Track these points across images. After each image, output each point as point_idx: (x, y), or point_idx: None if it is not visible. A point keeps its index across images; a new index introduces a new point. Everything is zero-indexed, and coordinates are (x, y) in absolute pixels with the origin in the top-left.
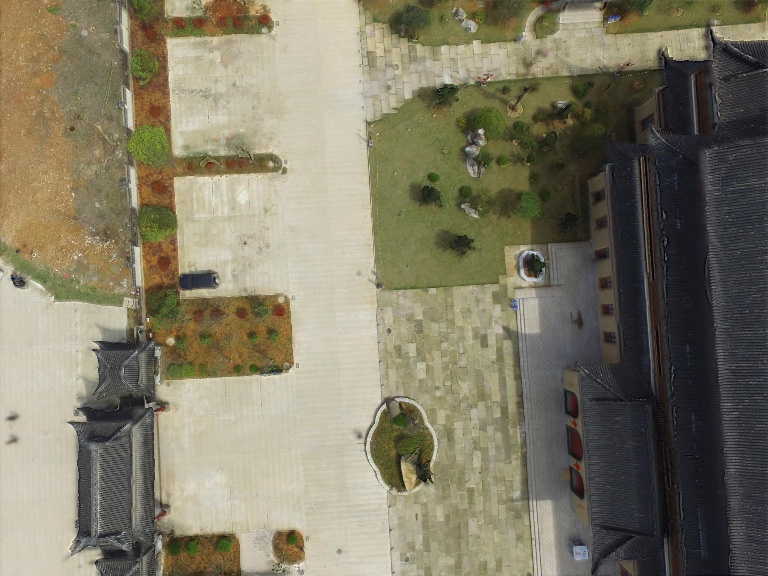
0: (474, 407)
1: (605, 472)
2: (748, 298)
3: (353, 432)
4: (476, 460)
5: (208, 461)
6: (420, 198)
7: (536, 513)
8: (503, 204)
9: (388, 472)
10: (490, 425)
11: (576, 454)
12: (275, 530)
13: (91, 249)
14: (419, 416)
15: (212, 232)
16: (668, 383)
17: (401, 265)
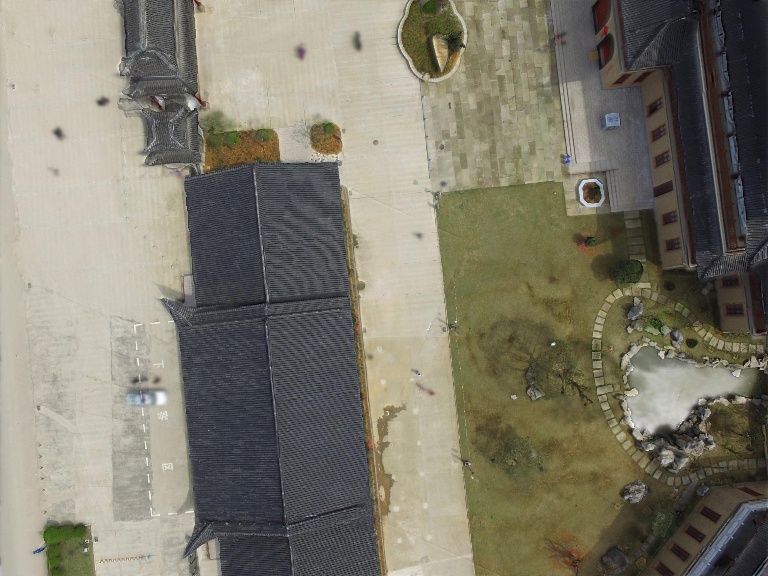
0: None
1: None
2: None
3: (384, 27)
4: (505, 49)
5: (244, 60)
6: None
7: (567, 95)
8: None
9: (420, 58)
10: (518, 15)
11: (604, 23)
12: (312, 123)
13: None
14: (448, 5)
15: None
16: None
17: None
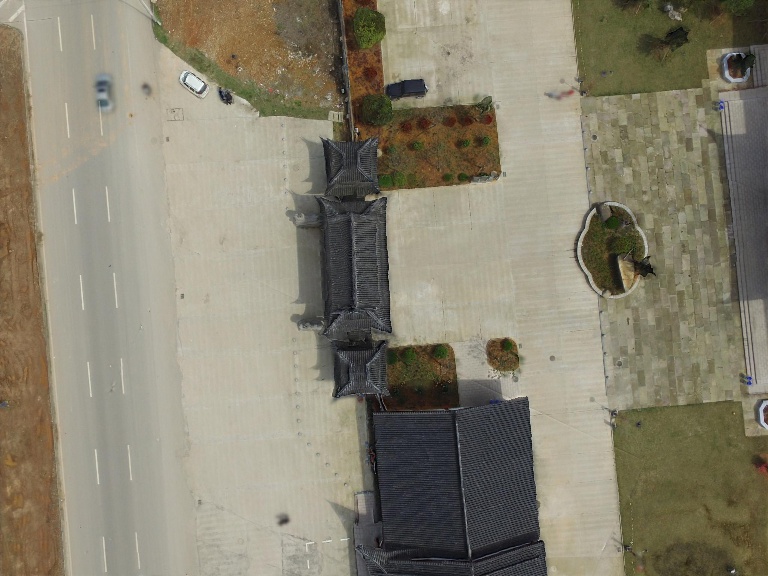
0: (682, 211)
1: None
2: None
3: (562, 239)
4: (685, 263)
5: (419, 271)
6: (623, 3)
7: (748, 313)
8: (705, 7)
9: (601, 275)
10: (698, 228)
11: None
12: (488, 338)
13: (295, 63)
14: (629, 219)
15: (415, 43)
16: None
17: None
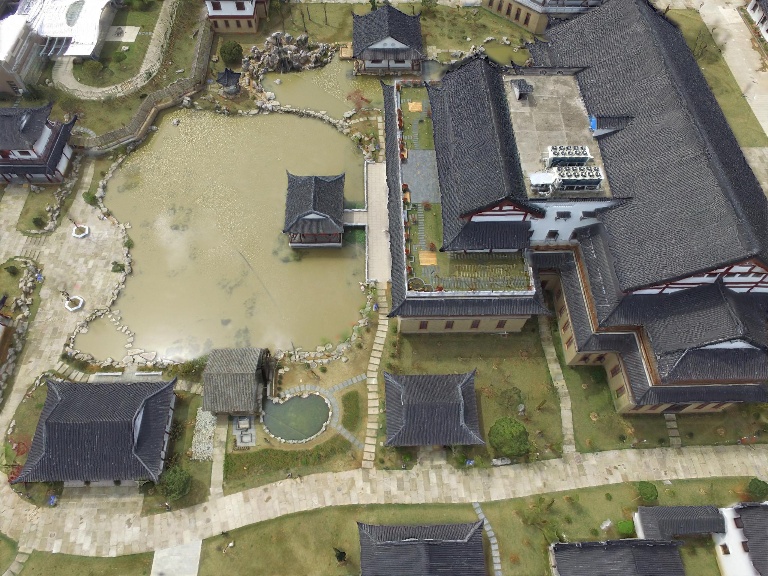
0: None
1: None
2: (766, 211)
3: None
4: None
5: None
6: None
7: None
8: None
9: None
10: None
11: None
12: None
13: None
14: None
15: None
16: None
17: None
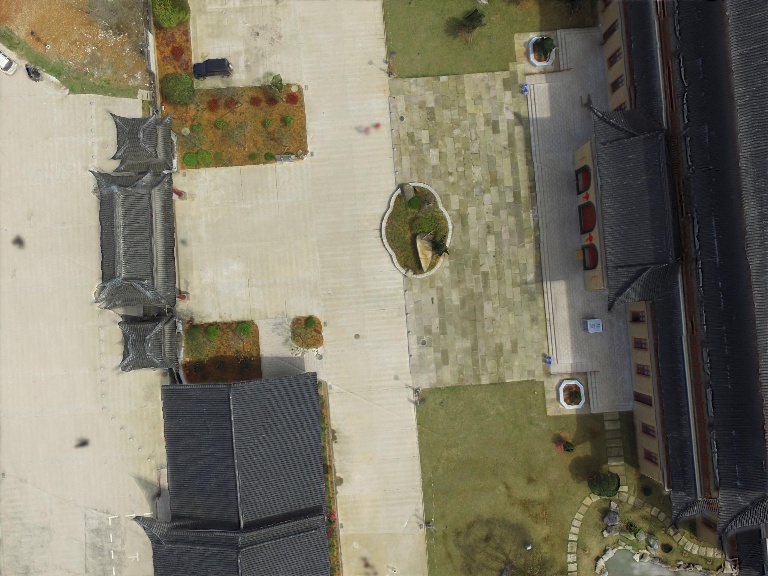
0: (487, 192)
1: (620, 213)
2: None
3: (368, 219)
4: (490, 244)
5: (225, 249)
6: None
7: (550, 294)
8: None
9: (404, 254)
10: (503, 210)
11: (589, 228)
12: (293, 316)
13: (105, 41)
14: (433, 200)
15: (224, 23)
16: (680, 114)
17: (412, 53)
